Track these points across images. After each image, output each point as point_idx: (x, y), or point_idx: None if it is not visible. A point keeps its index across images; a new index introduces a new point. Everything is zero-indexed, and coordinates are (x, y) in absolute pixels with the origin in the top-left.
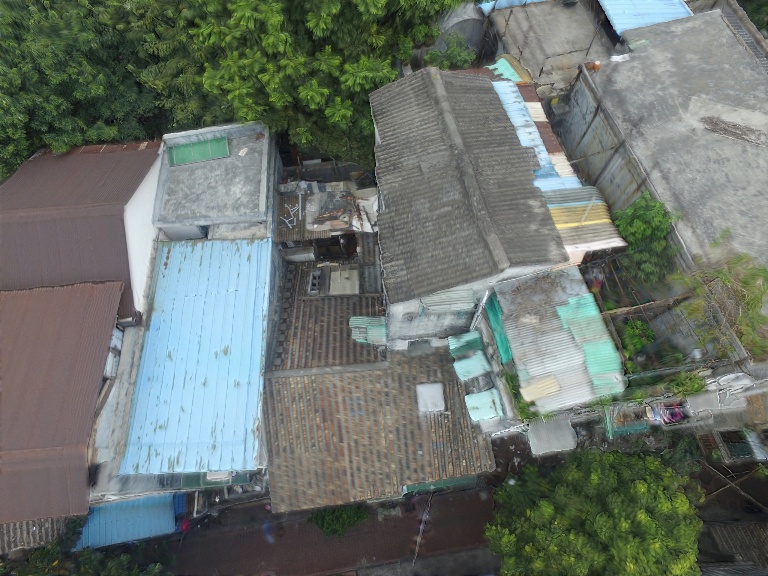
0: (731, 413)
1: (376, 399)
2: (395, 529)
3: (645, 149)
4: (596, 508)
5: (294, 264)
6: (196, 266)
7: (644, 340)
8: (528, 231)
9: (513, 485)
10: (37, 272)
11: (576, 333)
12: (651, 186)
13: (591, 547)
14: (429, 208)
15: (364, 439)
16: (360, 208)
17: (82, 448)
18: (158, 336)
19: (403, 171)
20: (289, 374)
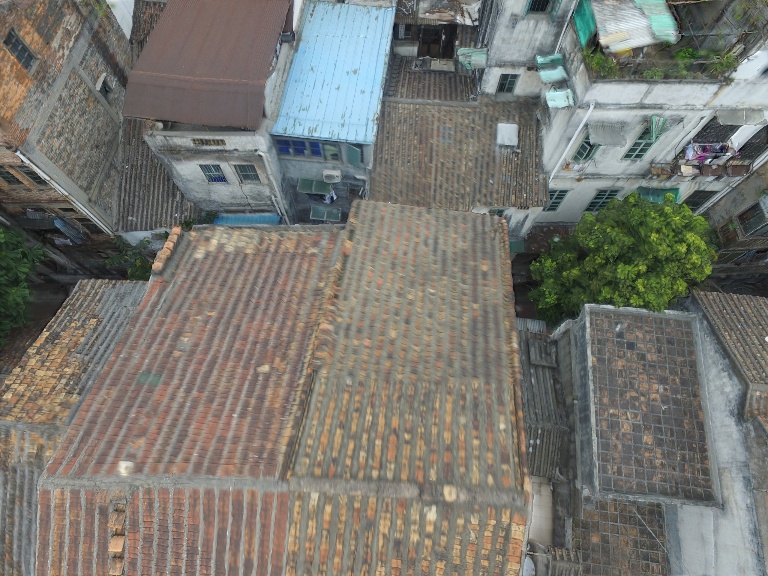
0: (751, 190)
1: (464, 132)
2: None
3: None
4: None
5: (400, 55)
6: (335, 18)
7: (693, 60)
8: None
9: (557, 242)
10: None
11: (646, 10)
12: None
13: (623, 236)
14: None
15: (449, 164)
16: (464, 10)
17: (262, 82)
18: (304, 56)
19: None
20: (399, 100)
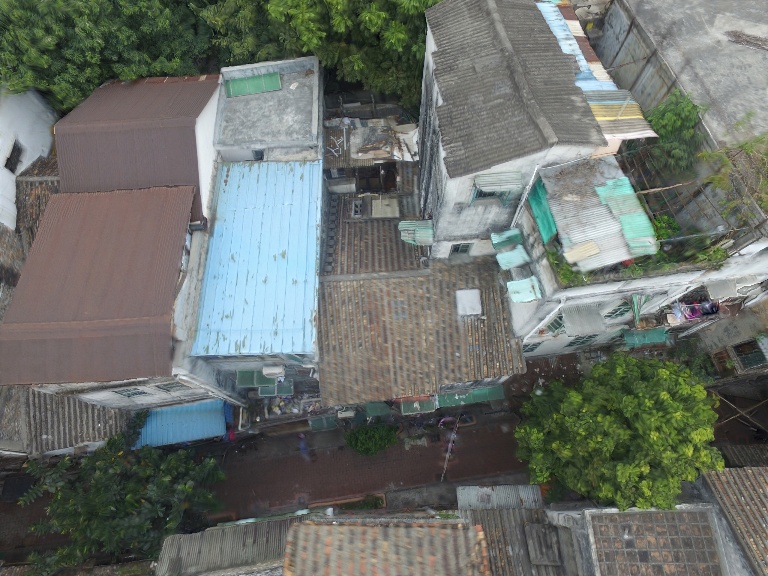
0: (745, 325)
1: (418, 304)
2: (421, 457)
3: (675, 57)
4: (622, 395)
5: (337, 194)
6: (254, 183)
7: (670, 232)
8: (572, 120)
9: (540, 396)
10: (115, 178)
11: (613, 208)
12: (680, 86)
13: (617, 427)
14: (483, 100)
15: (407, 341)
16: (400, 141)
17: (167, 318)
18: (222, 241)
19: (459, 72)
20: (340, 278)
